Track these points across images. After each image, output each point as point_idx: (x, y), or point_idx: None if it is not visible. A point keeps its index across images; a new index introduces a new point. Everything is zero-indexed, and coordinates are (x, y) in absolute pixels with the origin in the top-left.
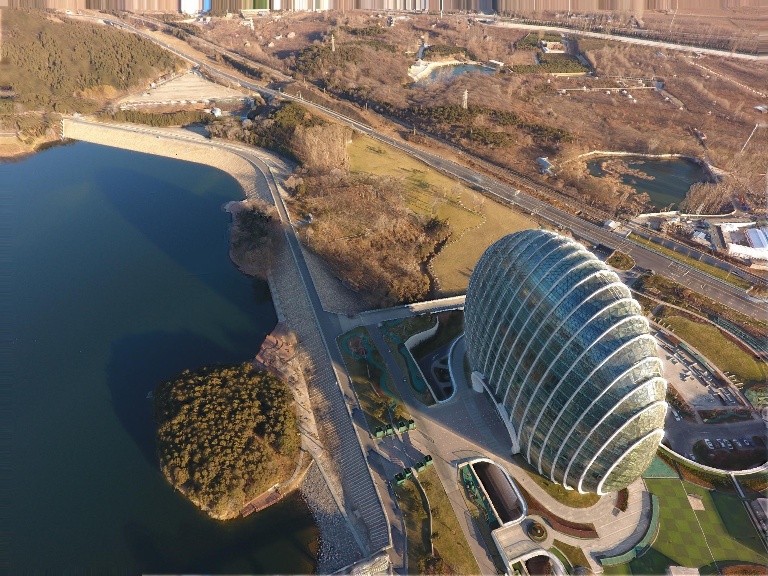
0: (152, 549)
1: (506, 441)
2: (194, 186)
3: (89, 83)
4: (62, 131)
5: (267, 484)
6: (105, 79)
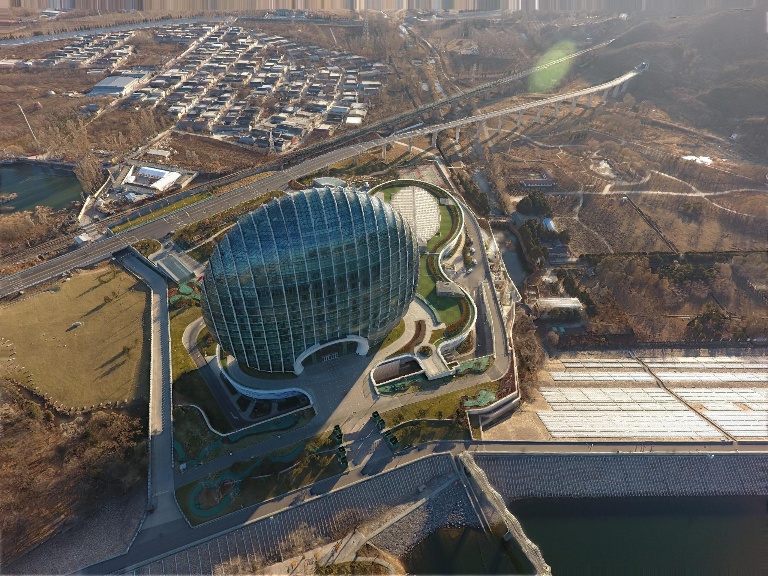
0: None
1: (354, 358)
2: None
3: None
4: None
5: None
6: None
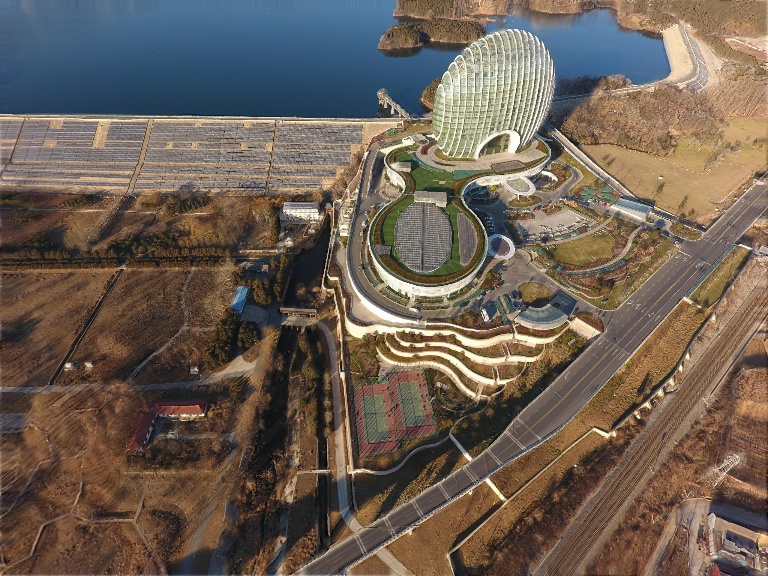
0: (410, 91)
1: None
2: (639, 71)
3: (748, 21)
4: (665, 29)
5: None
6: (760, 22)
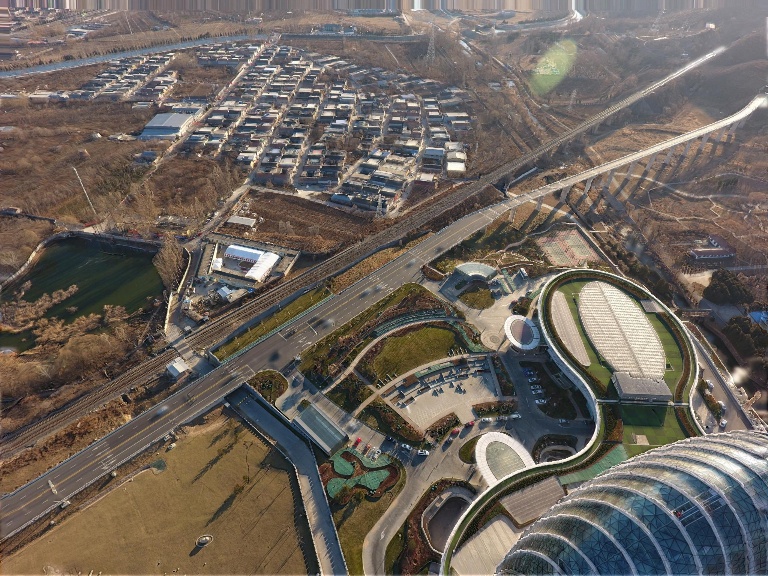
0: None
1: None
2: None
3: None
4: None
5: None
6: None
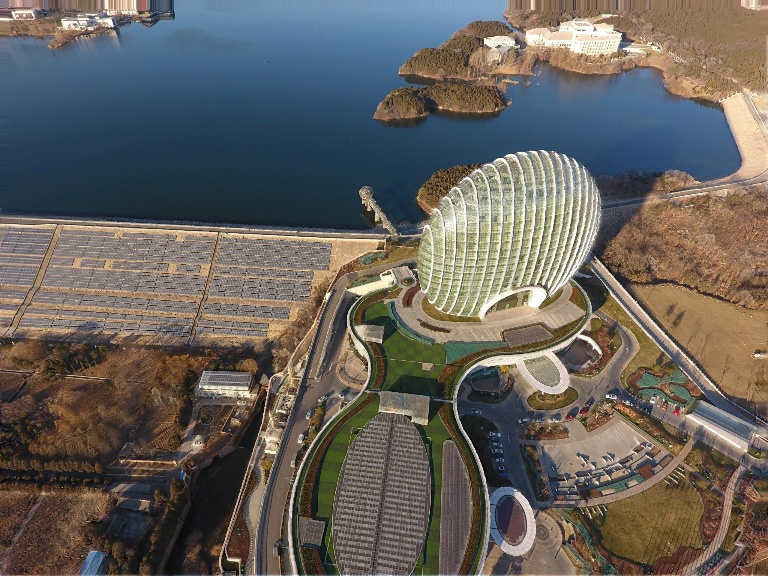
0: (404, 184)
1: None
2: (700, 159)
3: None
4: (725, 98)
5: (433, 204)
6: None
